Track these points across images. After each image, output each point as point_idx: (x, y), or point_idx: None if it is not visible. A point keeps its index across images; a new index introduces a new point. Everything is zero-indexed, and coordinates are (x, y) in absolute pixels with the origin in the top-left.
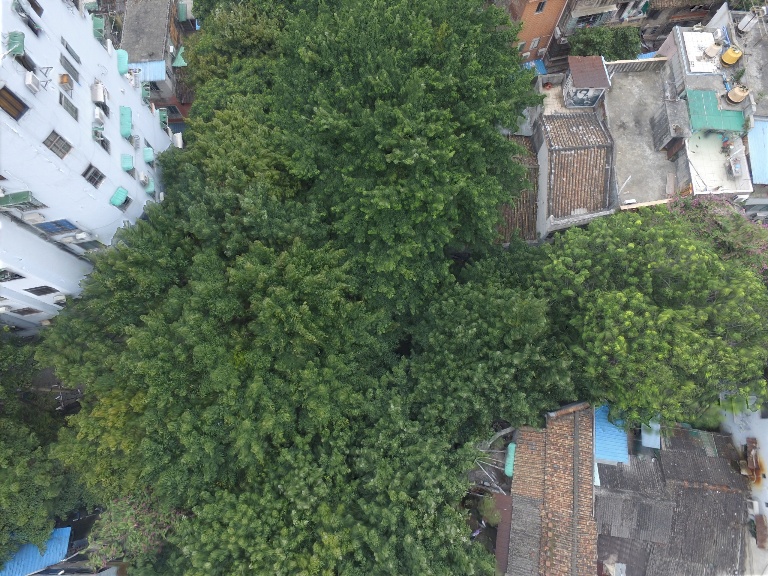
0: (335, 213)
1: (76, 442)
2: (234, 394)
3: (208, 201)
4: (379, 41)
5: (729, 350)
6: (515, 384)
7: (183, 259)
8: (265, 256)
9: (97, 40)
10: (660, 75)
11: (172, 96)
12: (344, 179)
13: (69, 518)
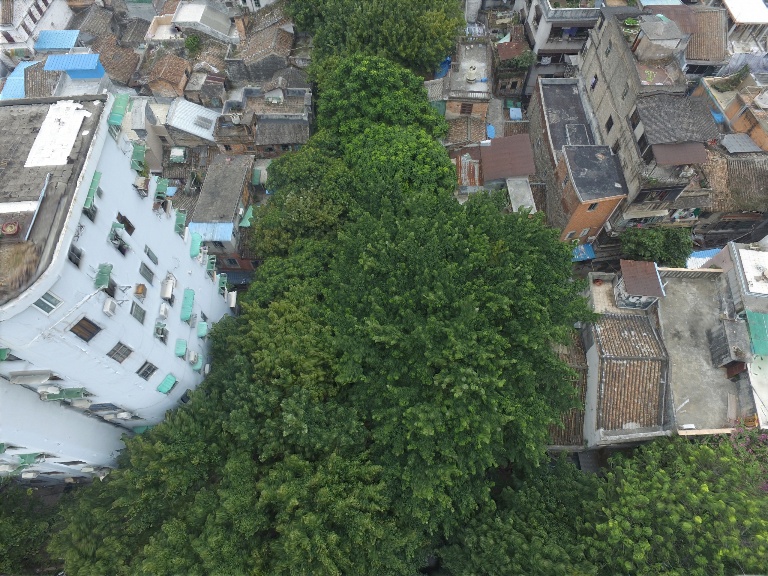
0: None
1: None
2: None
3: (251, 398)
4: (437, 254)
5: None
6: None
7: (216, 455)
8: (299, 468)
9: (176, 233)
10: (715, 284)
11: (234, 252)
12: (389, 389)
13: None
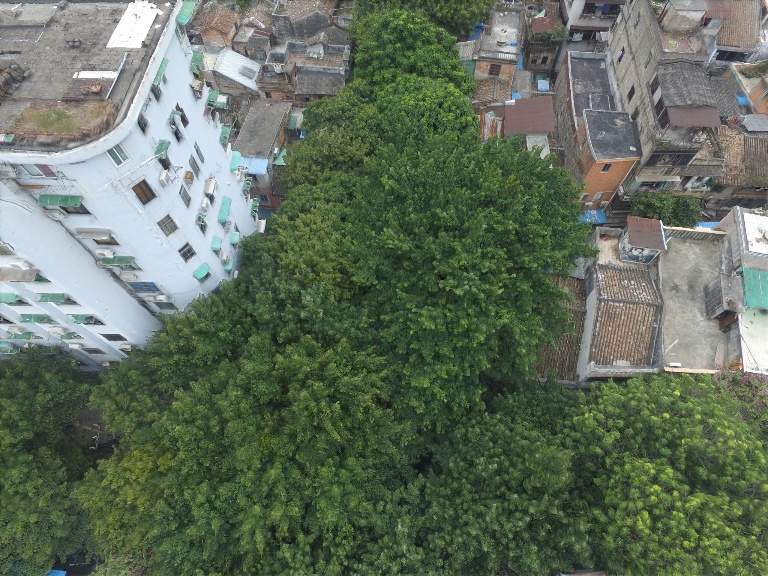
0: (384, 321)
1: (99, 487)
2: (253, 476)
3: (275, 290)
4: (452, 181)
5: (764, 554)
6: (528, 534)
7: (240, 336)
8: (312, 349)
9: (221, 144)
10: (718, 247)
11: (266, 187)
12: (398, 293)
13: (67, 561)
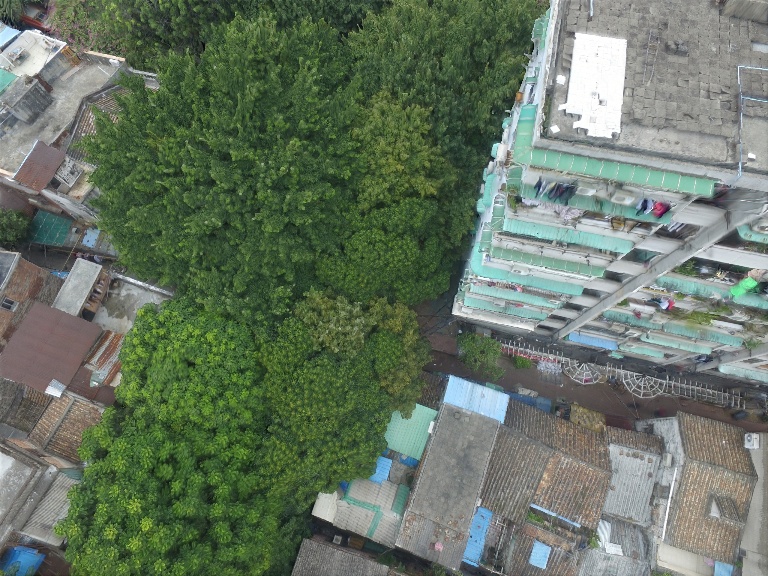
0: None
1: None
2: None
3: None
4: None
5: None
6: None
7: None
8: None
9: None
10: None
11: None
12: None
13: None
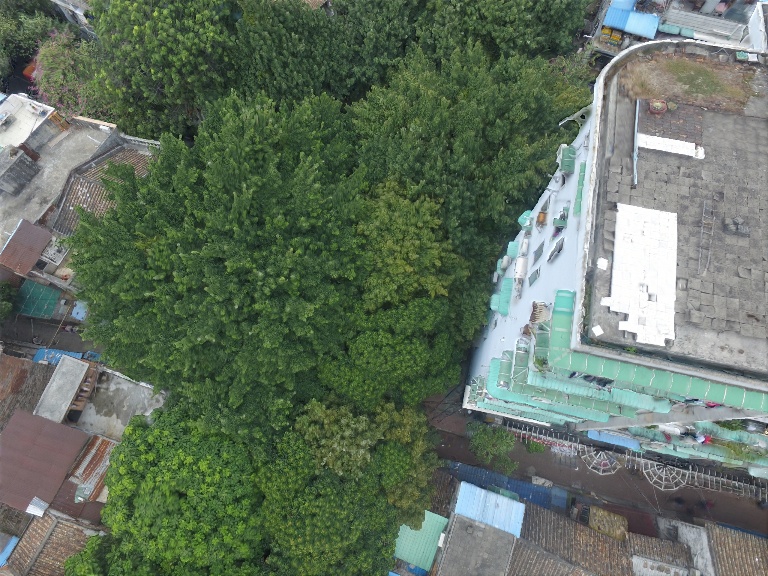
0: None
1: None
2: None
3: None
4: None
5: None
6: None
7: None
8: None
9: None
10: None
11: None
12: None
13: None
